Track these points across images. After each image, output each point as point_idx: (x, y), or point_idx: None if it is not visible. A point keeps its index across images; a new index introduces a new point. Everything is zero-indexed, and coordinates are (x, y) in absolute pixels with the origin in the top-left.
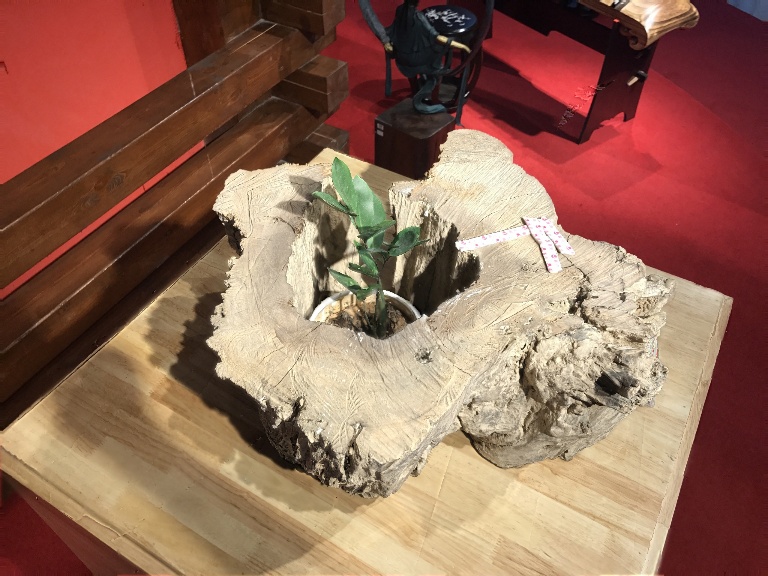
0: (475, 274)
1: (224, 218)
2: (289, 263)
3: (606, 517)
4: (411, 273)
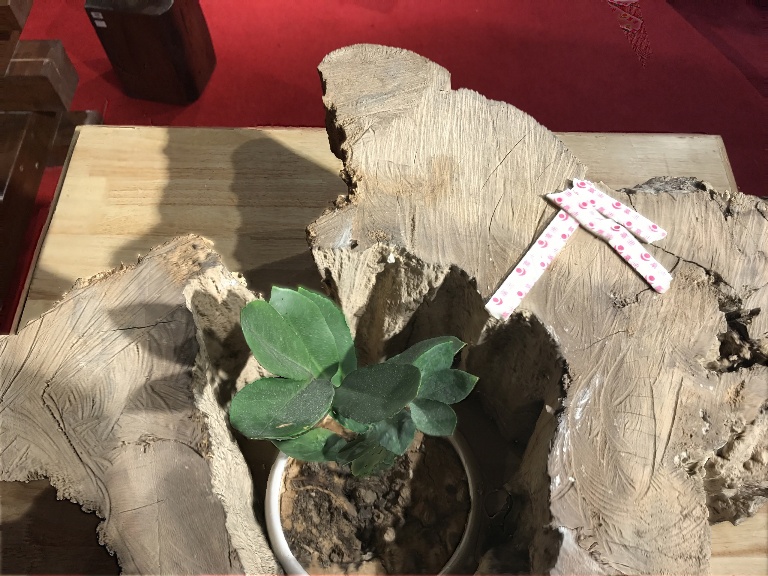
0: (526, 335)
1: None
2: (230, 533)
3: None
4: (370, 330)
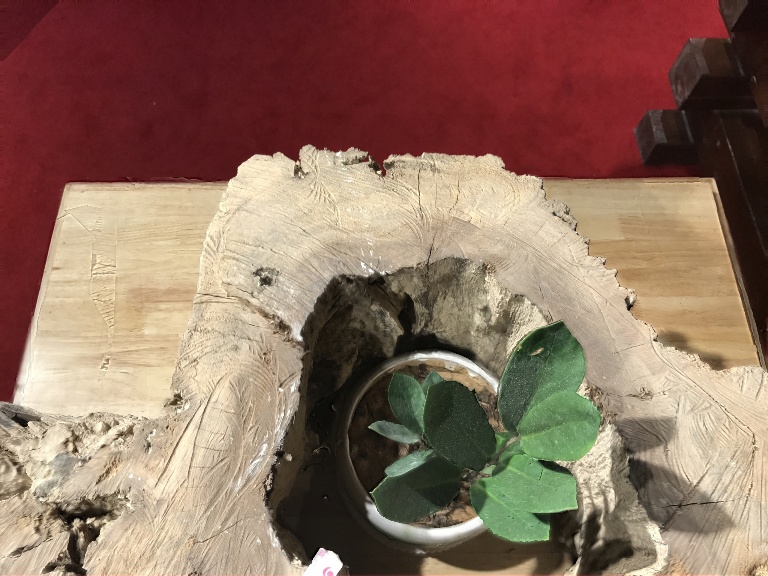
0: None
1: None
2: None
3: None
4: None
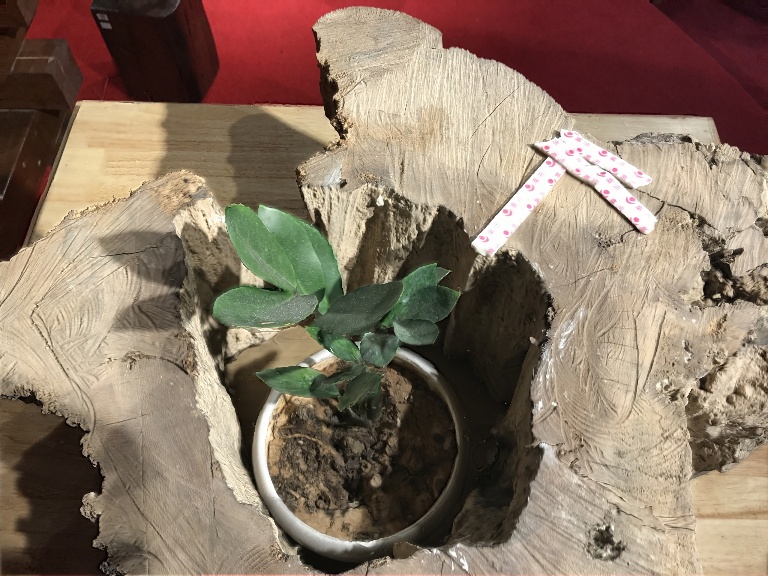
0: (513, 278)
1: (9, 396)
2: (213, 447)
3: (767, 506)
4: None
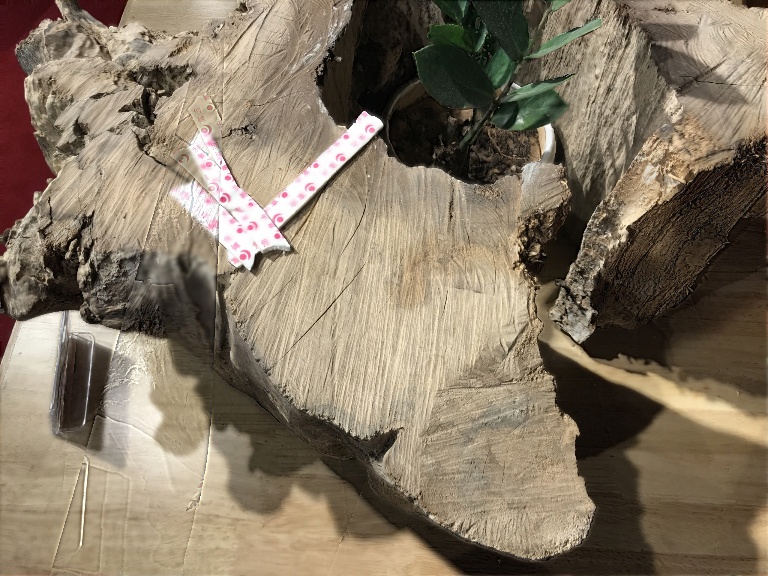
0: None
1: None
2: None
3: None
4: None
